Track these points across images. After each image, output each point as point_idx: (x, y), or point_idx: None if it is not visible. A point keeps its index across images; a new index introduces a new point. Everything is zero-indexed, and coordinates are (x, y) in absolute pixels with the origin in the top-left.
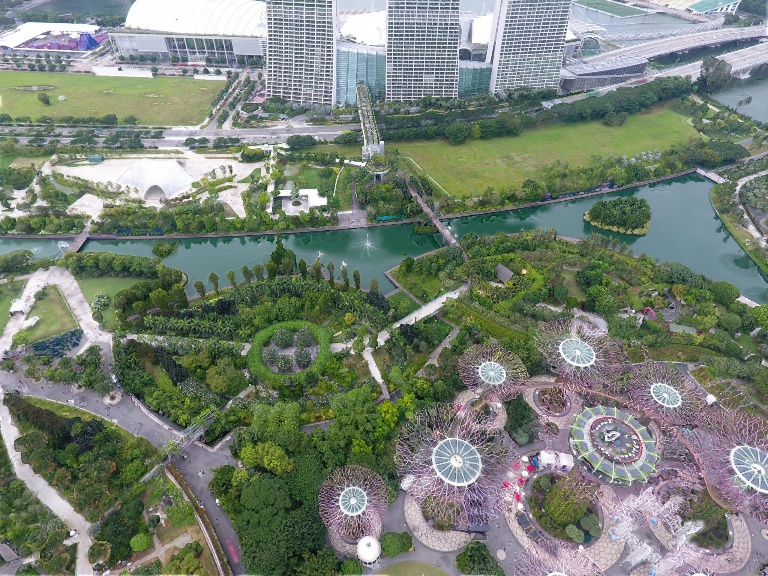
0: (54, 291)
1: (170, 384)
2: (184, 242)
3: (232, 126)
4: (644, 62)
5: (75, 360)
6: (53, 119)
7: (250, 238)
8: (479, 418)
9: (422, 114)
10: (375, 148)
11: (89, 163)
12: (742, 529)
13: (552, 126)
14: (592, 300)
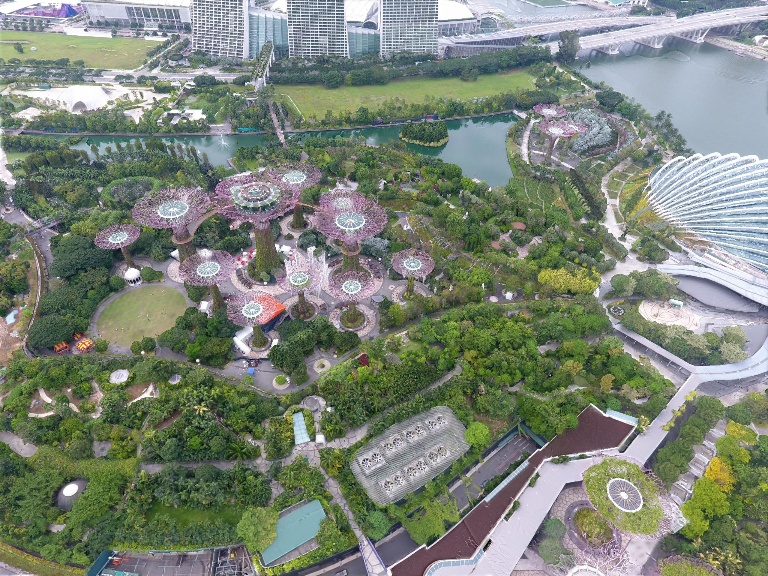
0: None
1: (44, 201)
2: (94, 140)
3: (160, 71)
4: (519, 36)
5: None
6: (21, 61)
7: (143, 139)
8: (199, 194)
9: None
10: (256, 84)
11: (39, 89)
12: (378, 284)
13: (418, 79)
14: (355, 172)
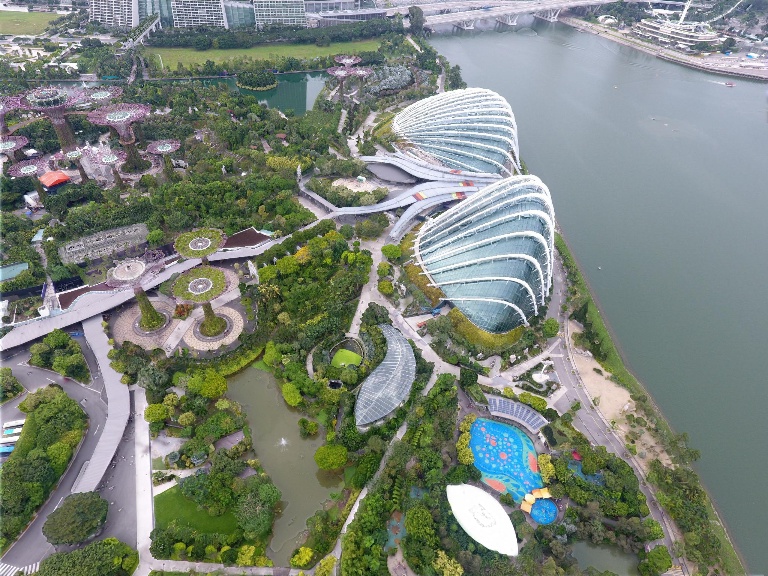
0: None
1: None
2: None
3: (58, 36)
4: (382, 12)
5: None
6: None
7: None
8: None
9: (185, 32)
10: None
11: None
12: None
13: (279, 45)
14: None
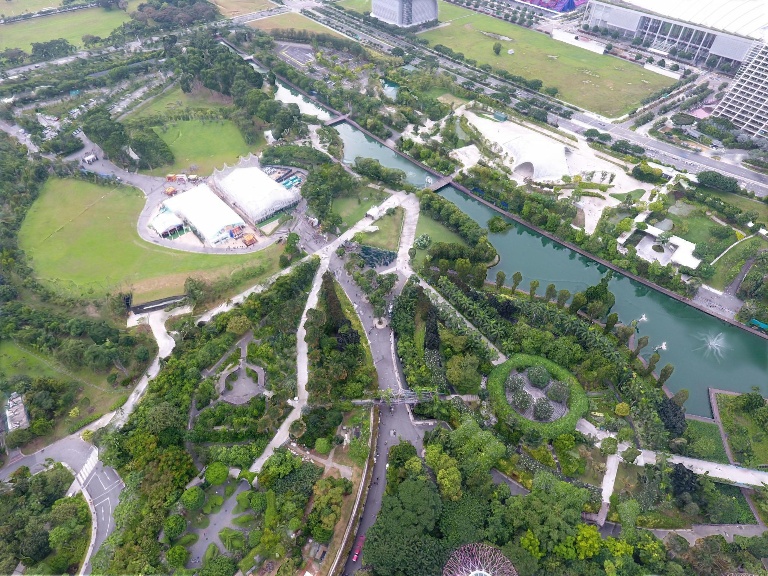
0: (401, 213)
1: (421, 344)
2: (519, 226)
3: (648, 132)
4: None
5: (377, 277)
6: (492, 69)
7: (581, 257)
8: None
9: None
10: None
11: (493, 118)
12: None
13: None
14: None
